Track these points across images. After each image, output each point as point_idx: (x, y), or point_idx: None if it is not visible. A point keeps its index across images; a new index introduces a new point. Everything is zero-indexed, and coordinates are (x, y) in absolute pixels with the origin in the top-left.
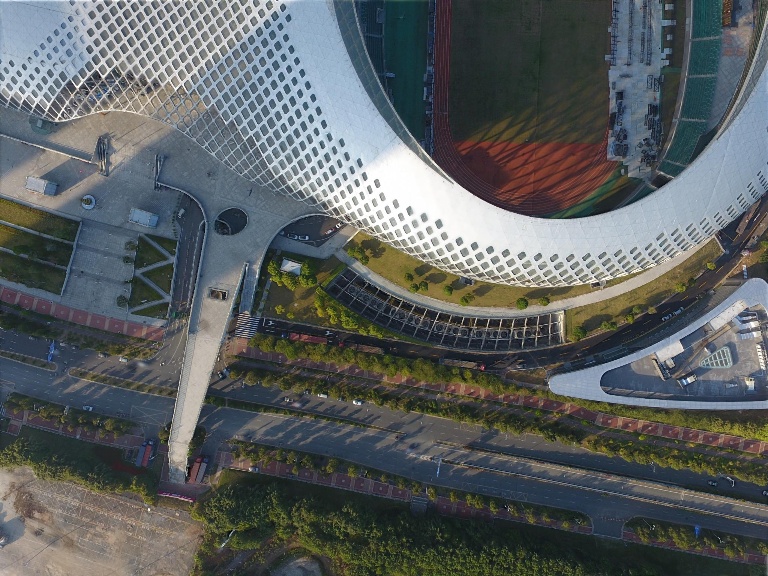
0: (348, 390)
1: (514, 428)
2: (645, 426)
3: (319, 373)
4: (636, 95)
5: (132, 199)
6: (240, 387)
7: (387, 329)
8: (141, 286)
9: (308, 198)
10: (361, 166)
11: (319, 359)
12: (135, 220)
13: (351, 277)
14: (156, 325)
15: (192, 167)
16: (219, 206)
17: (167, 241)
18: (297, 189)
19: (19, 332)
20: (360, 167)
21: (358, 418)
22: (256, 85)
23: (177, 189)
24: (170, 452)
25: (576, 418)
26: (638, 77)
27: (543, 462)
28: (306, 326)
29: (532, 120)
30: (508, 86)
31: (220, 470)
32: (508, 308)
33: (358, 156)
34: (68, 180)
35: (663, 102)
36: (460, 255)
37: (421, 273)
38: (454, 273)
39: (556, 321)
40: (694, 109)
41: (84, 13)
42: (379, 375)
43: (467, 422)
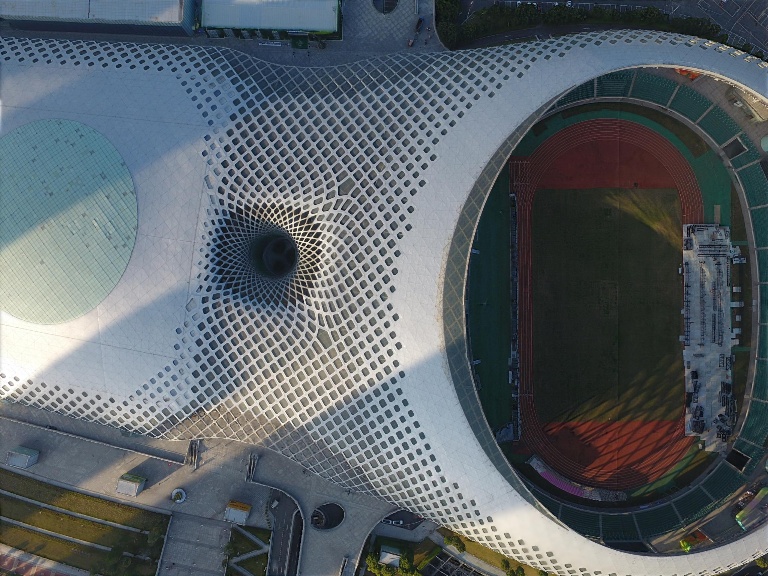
0: None
1: None
2: None
3: None
4: (710, 373)
5: (223, 491)
6: None
7: None
8: (235, 575)
9: (413, 512)
10: (474, 505)
11: None
12: (231, 519)
13: (445, 558)
14: None
15: (287, 464)
16: (315, 502)
17: (261, 532)
18: (402, 506)
19: None
20: (473, 505)
21: None
22: (367, 428)
23: (273, 488)
24: None
25: None
26: (711, 356)
27: None
28: None
29: (614, 400)
30: (589, 368)
31: None
32: None
33: (472, 498)
34: (157, 474)
35: (735, 379)
36: (567, 572)
37: None
38: None
39: None
40: (766, 391)
41: (189, 357)
42: None
43: None
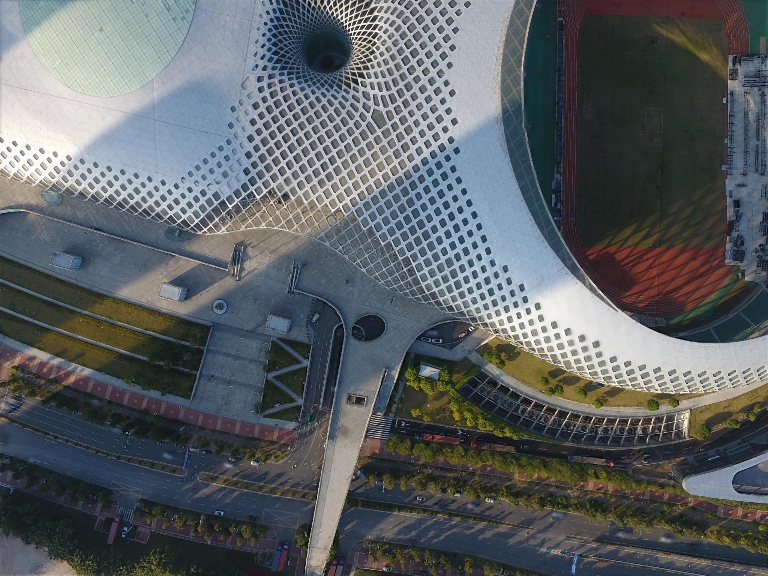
0: (480, 488)
1: (646, 524)
2: (763, 516)
3: (451, 472)
4: (751, 203)
5: (264, 303)
6: (373, 487)
7: (519, 428)
8: (273, 390)
9: (457, 312)
10: (523, 290)
11: (457, 461)
12: (272, 327)
13: (483, 378)
14: (288, 428)
15: (330, 274)
16: (357, 313)
17: (301, 345)
18: (448, 304)
19: (153, 441)
20: (522, 291)
21: (490, 515)
22: (418, 211)
23: None
24: (308, 557)
25: (699, 510)
26: (753, 186)
27: (670, 554)
28: (438, 426)
29: (655, 226)
30: (632, 194)
31: (354, 570)
32: (637, 408)
33: (521, 282)
34: (198, 285)
35: None
36: (611, 370)
37: (555, 376)
38: (595, 381)
39: (681, 419)
40: None
41: (243, 136)
42: (510, 473)
43: (598, 518)
